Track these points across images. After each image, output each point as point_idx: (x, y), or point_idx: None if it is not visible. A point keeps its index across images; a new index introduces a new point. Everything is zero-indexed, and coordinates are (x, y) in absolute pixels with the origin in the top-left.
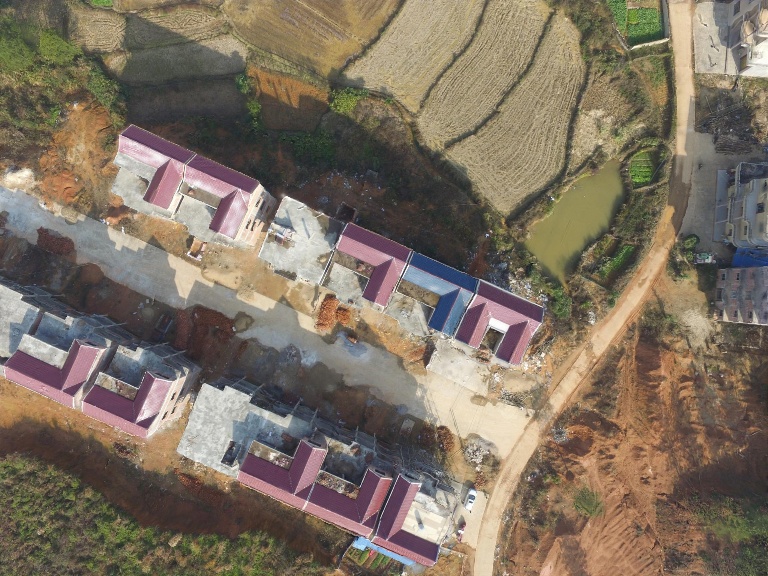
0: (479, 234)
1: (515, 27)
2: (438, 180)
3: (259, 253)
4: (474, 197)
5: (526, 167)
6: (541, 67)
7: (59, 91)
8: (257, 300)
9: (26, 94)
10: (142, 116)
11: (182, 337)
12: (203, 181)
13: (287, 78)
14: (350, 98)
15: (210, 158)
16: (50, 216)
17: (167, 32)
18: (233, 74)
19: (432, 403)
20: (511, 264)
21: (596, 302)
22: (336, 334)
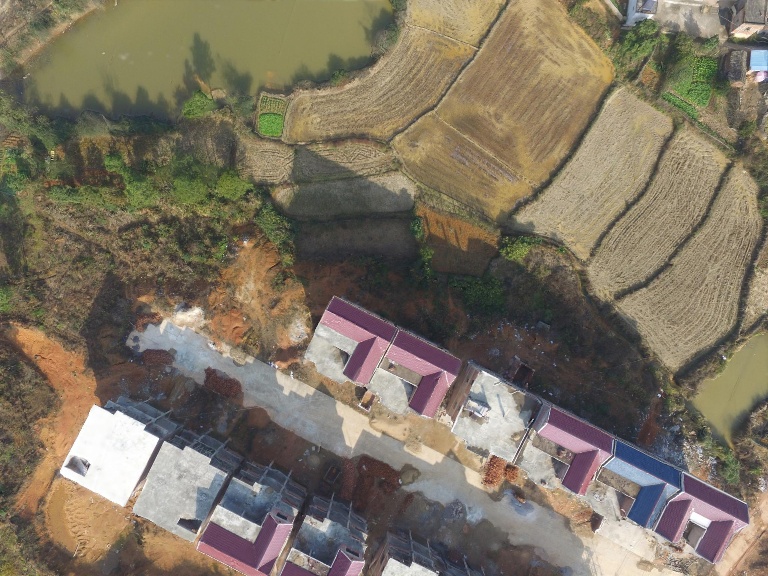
0: (652, 395)
1: (691, 177)
2: (611, 336)
3: (452, 428)
4: (642, 351)
5: (697, 323)
6: (716, 220)
7: (226, 223)
8: (424, 453)
9: (192, 224)
10: (308, 252)
11: (348, 488)
12: (406, 359)
13: (456, 219)
14: (524, 247)
15: (382, 304)
16: (218, 356)
17: (335, 166)
18: (401, 212)
19: (598, 567)
20: (684, 428)
21: (766, 468)
22: (503, 491)
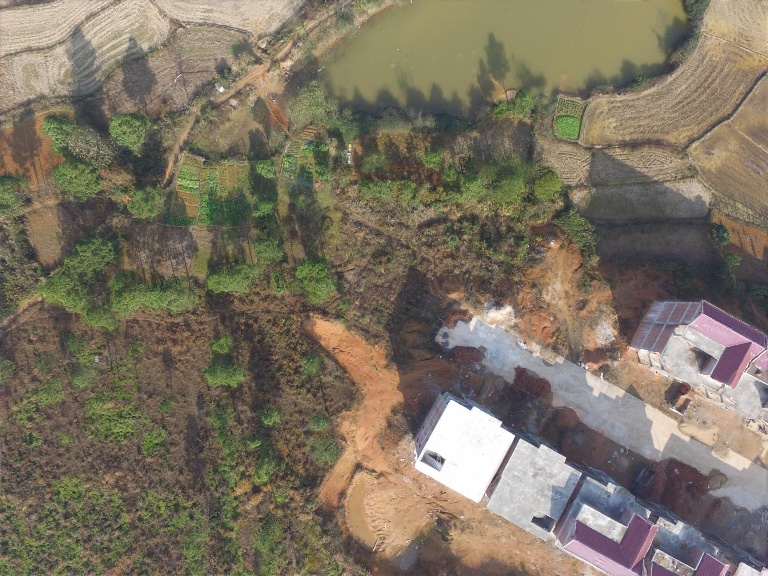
0: None
1: None
2: None
3: None
4: None
5: None
6: None
7: None
8: (732, 458)
9: (492, 223)
10: (607, 255)
11: (658, 491)
12: None
13: (751, 228)
14: None
15: None
16: (528, 355)
17: (631, 170)
18: (697, 219)
19: None
20: None
21: None
22: None
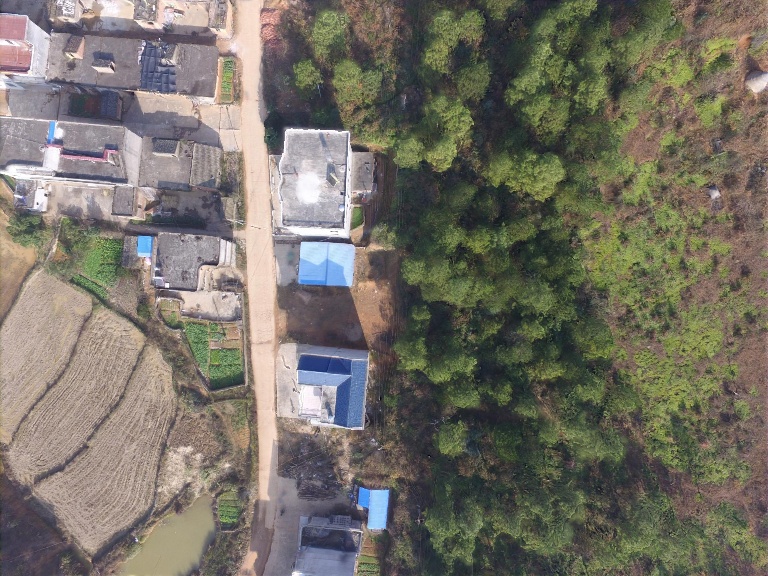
0: None
1: (108, 357)
2: (12, 527)
3: None
4: (62, 534)
5: (114, 504)
6: (132, 400)
7: None
8: None
9: None
10: None
11: None
12: None
13: None
14: None
15: None
16: None
17: None
18: None
19: None
20: None
21: None
22: None
